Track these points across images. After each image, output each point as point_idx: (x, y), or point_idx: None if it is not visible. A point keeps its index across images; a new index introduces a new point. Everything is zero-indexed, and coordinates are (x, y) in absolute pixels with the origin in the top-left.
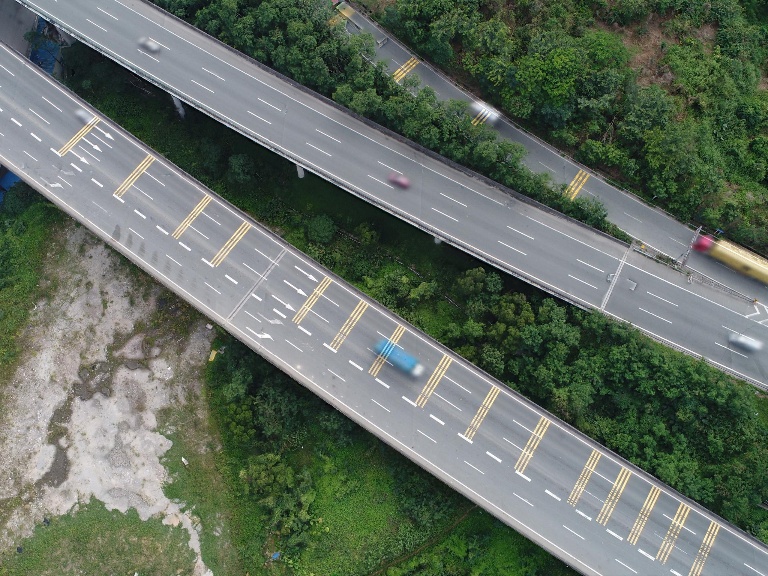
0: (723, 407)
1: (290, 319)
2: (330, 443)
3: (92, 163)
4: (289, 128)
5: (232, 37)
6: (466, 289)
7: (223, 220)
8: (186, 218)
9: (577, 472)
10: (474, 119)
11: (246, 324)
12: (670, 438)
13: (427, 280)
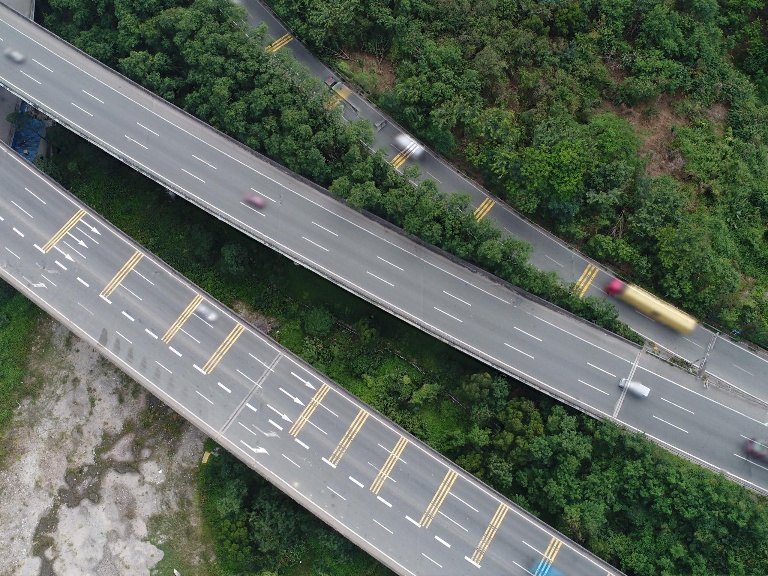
0: (744, 529)
1: (286, 431)
2: (330, 559)
3: (77, 260)
4: (284, 221)
5: (224, 122)
6: (471, 396)
7: (215, 322)
8: (176, 320)
9: None
10: (477, 209)
11: (240, 437)
12: (688, 559)
13: (430, 378)
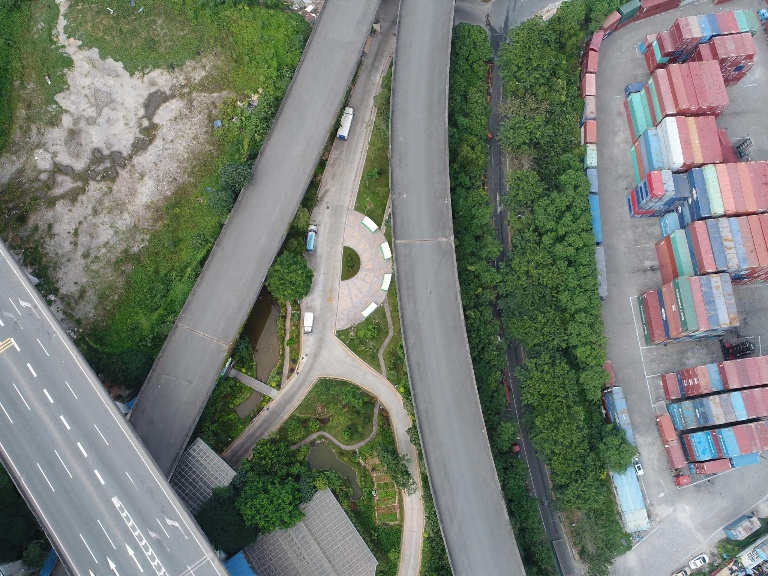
0: None
1: None
2: None
3: None
4: None
5: None
6: None
7: None
8: None
9: None
10: None
11: None
12: None
13: None
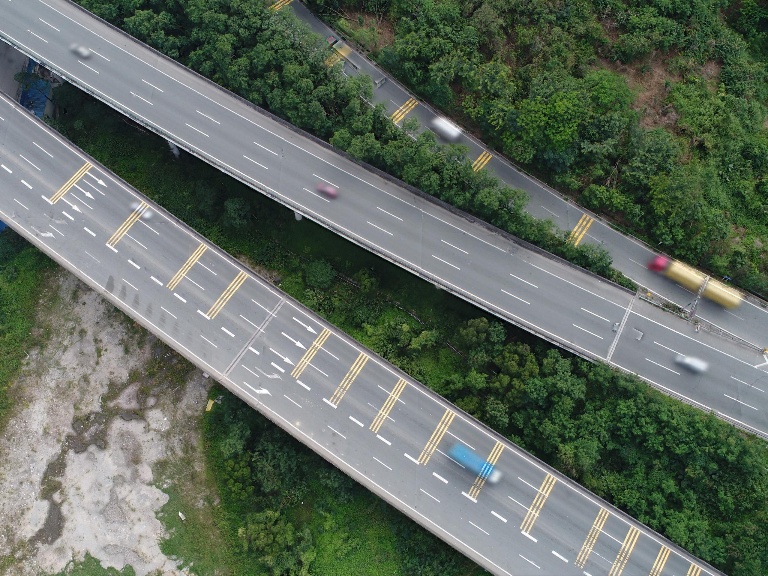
0: (733, 464)
1: (288, 373)
2: (331, 499)
3: (84, 211)
4: (286, 173)
5: (227, 79)
6: (468, 340)
7: (219, 270)
8: (181, 268)
9: (584, 532)
10: (475, 162)
11: (243, 379)
12: (679, 495)
13: (428, 327)
